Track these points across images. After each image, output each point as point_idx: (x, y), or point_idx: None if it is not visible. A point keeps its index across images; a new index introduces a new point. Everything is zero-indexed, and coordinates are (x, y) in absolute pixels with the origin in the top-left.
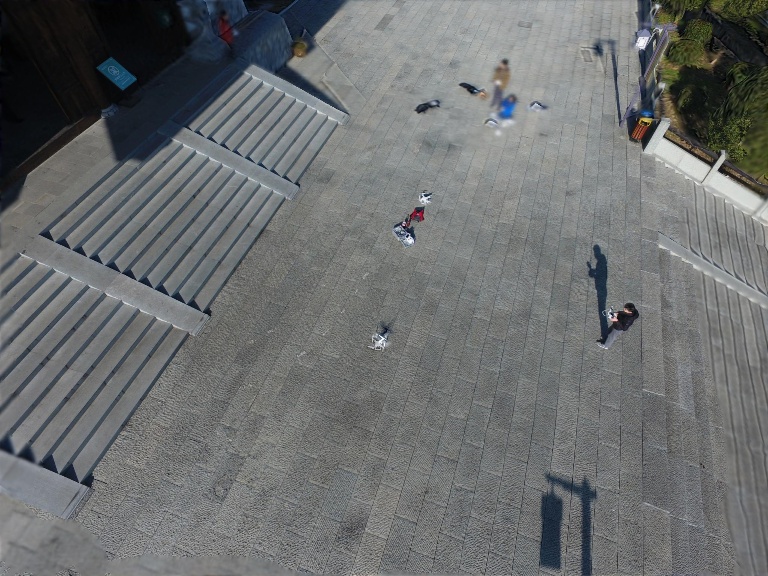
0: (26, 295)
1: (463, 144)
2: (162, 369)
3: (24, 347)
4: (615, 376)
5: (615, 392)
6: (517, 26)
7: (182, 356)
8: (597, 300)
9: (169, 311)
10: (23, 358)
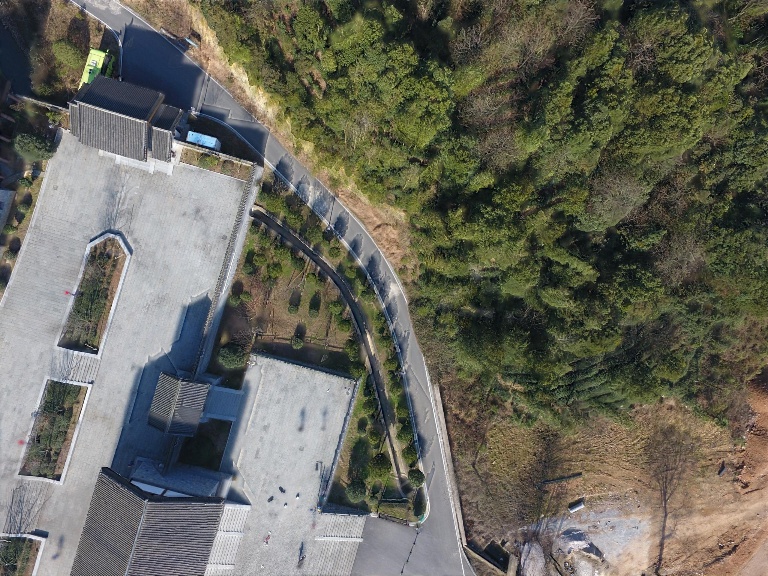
0: (207, 573)
1: (279, 514)
2: None
3: None
4: (299, 569)
5: (299, 571)
6: (299, 450)
7: (232, 572)
8: (299, 555)
9: (228, 567)
10: None
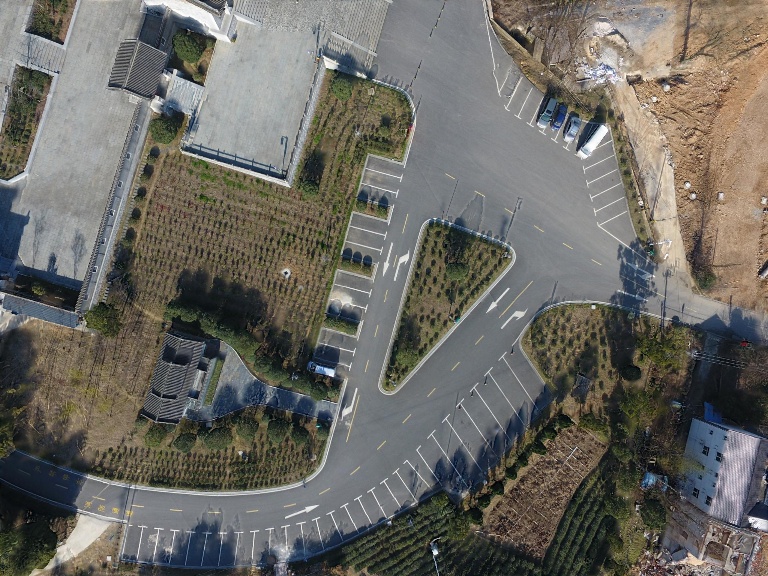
0: None
1: None
2: (266, 8)
3: (248, 4)
4: (332, 6)
5: (331, 8)
6: None
7: (268, 5)
8: None
9: None
10: (249, 6)
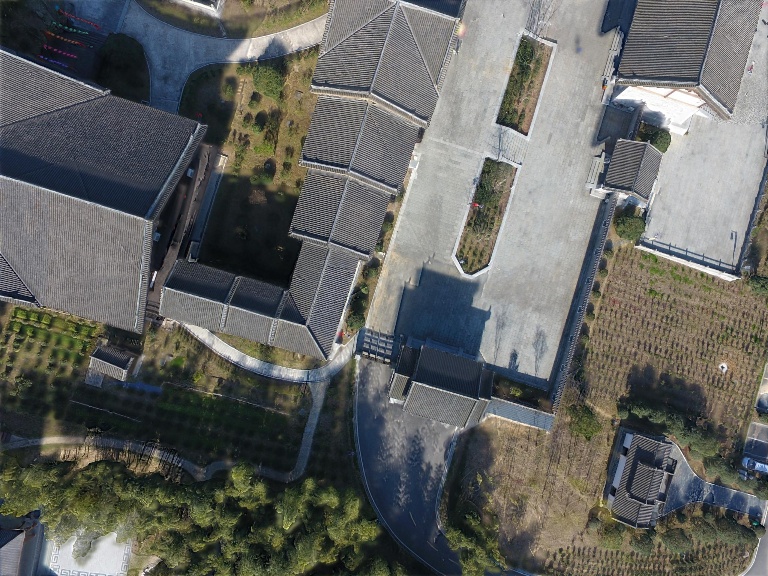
0: None
1: (762, 45)
2: None
3: None
4: None
5: None
6: None
7: None
8: None
9: None
10: None
